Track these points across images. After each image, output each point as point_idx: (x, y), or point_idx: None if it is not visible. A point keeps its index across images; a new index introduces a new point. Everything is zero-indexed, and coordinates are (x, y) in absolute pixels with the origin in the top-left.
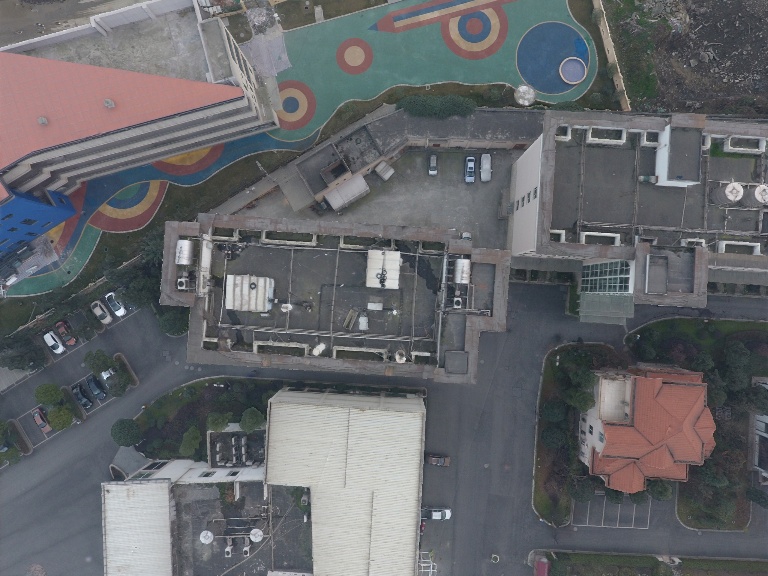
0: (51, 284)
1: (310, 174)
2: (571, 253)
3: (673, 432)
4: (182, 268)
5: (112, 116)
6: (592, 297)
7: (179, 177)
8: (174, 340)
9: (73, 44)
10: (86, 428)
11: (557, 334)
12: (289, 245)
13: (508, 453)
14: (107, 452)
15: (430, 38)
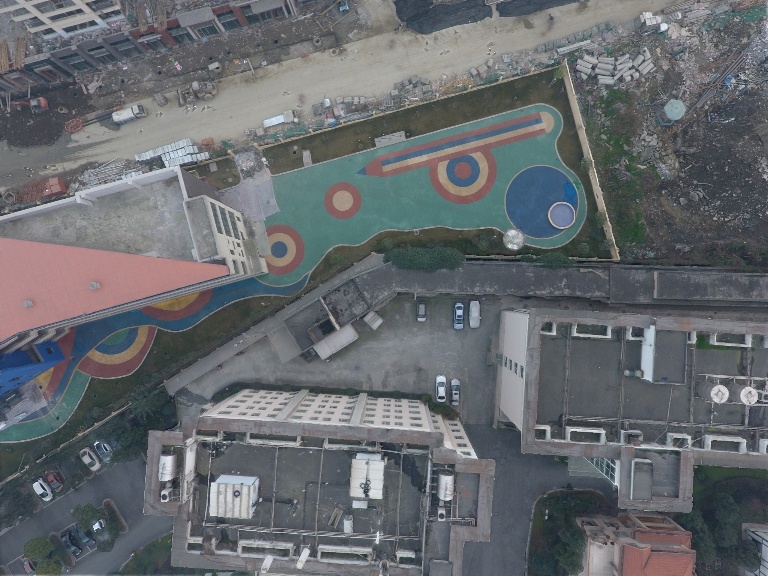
0: (40, 430)
1: (298, 329)
2: (556, 452)
3: None
4: None
5: (97, 296)
6: None
7: (168, 322)
8: None
9: (59, 214)
10: (75, 574)
11: (546, 480)
12: (273, 444)
13: None
14: None
15: (418, 182)
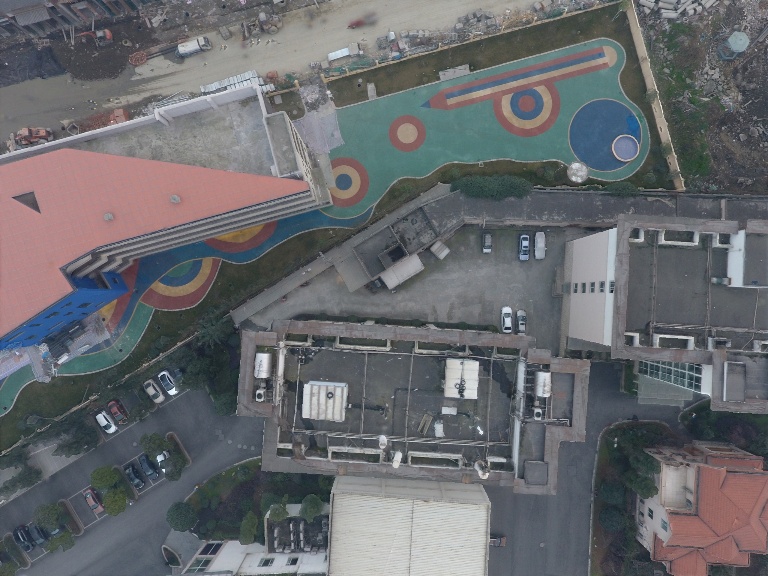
0: (103, 362)
1: (367, 256)
2: (646, 357)
3: (740, 525)
4: (259, 378)
5: (178, 211)
6: (651, 380)
7: (232, 254)
8: (227, 419)
9: (135, 134)
10: (138, 508)
11: (612, 412)
12: (363, 350)
13: (564, 532)
14: (159, 532)
15: (483, 115)
